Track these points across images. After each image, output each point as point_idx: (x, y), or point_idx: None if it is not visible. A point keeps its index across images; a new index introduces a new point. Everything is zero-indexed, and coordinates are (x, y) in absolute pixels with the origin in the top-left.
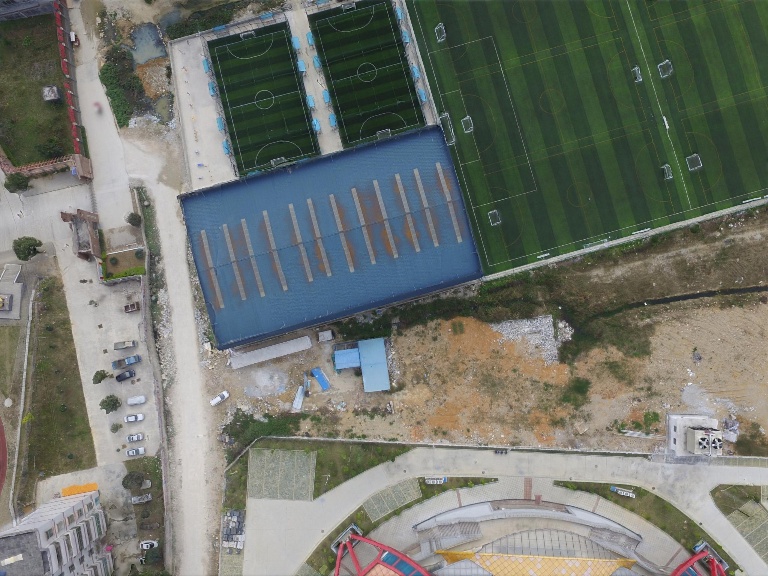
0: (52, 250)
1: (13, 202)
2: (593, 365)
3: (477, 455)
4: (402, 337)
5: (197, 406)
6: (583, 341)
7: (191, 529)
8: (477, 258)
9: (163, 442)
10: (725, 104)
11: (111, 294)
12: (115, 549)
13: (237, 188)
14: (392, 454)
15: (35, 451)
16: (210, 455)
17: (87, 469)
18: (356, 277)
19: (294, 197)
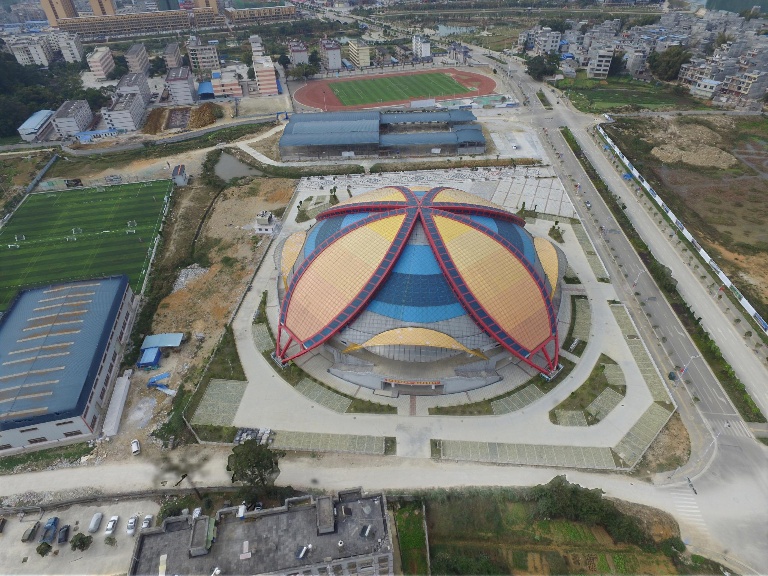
0: None
1: None
2: None
3: (248, 298)
4: (155, 332)
5: (134, 469)
6: (203, 260)
7: None
8: (115, 278)
9: None
10: (112, 216)
11: None
12: None
13: None
14: None
15: None
16: (183, 457)
17: None
18: (85, 330)
19: None
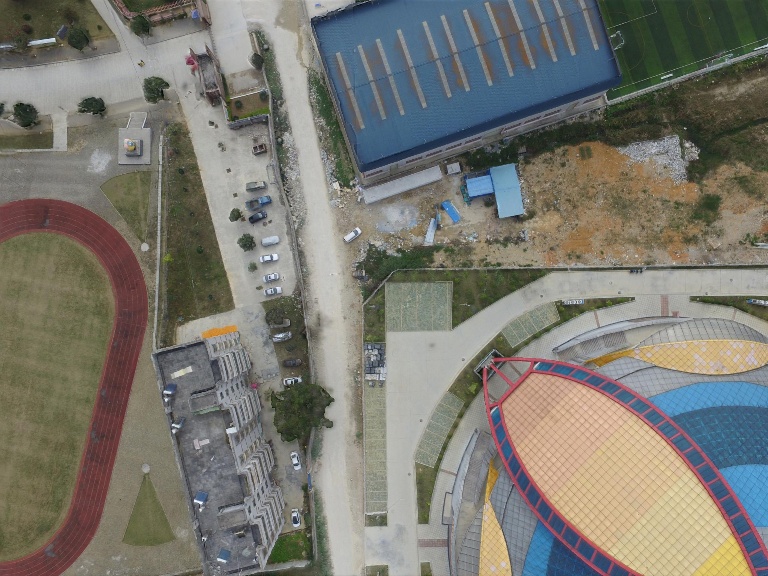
0: (175, 97)
1: (133, 51)
2: (723, 181)
3: (612, 276)
4: (530, 165)
5: (330, 245)
6: (710, 159)
7: (332, 365)
8: (615, 64)
9: (301, 279)
10: None
11: (237, 138)
12: (259, 388)
13: (369, 10)
14: (532, 274)
15: (173, 295)
16: (346, 292)
17: (225, 312)
18: (494, 91)
19: (427, 15)
